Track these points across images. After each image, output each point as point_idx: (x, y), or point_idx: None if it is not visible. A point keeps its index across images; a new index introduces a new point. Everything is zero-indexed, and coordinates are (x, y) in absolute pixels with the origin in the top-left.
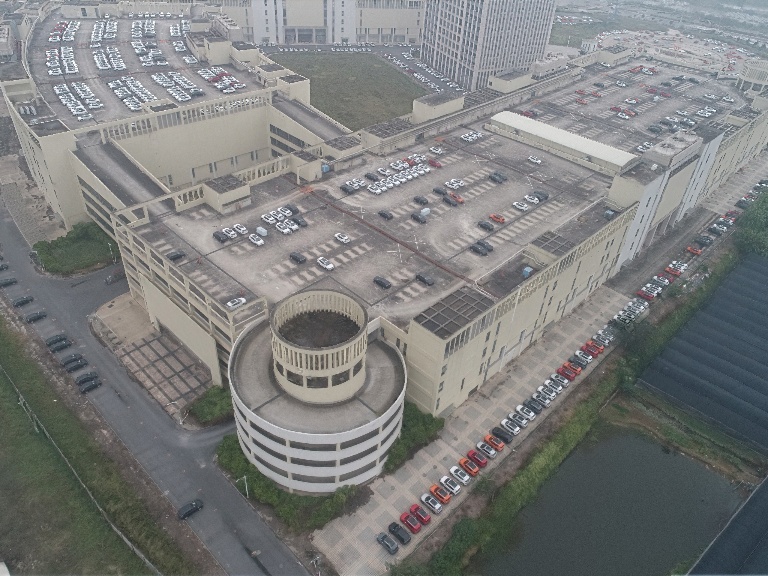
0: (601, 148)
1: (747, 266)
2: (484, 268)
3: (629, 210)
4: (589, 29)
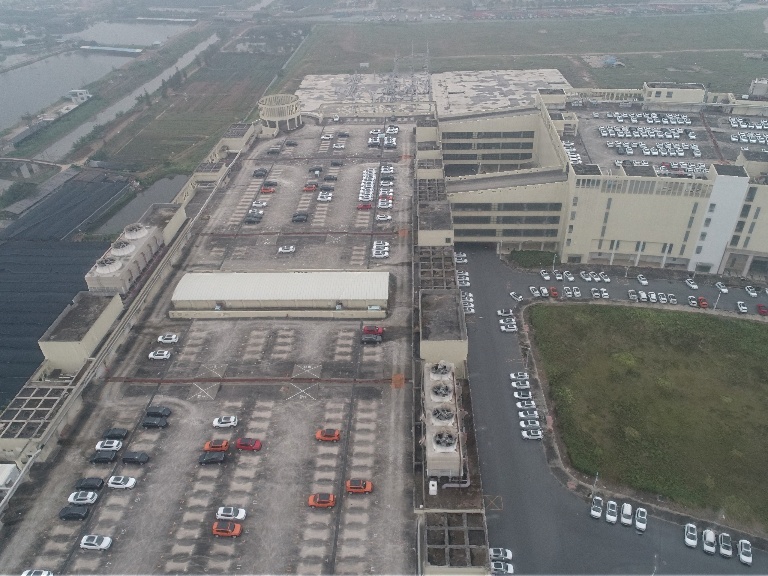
0: (221, 283)
1: (28, 378)
2: (249, 168)
3: None
4: None
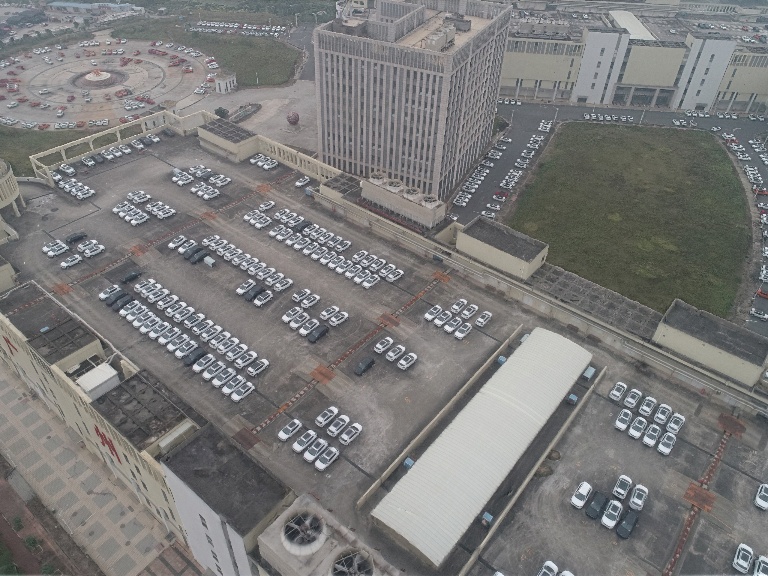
0: (626, 16)
1: None
2: None
3: (684, 3)
4: (2, 142)
